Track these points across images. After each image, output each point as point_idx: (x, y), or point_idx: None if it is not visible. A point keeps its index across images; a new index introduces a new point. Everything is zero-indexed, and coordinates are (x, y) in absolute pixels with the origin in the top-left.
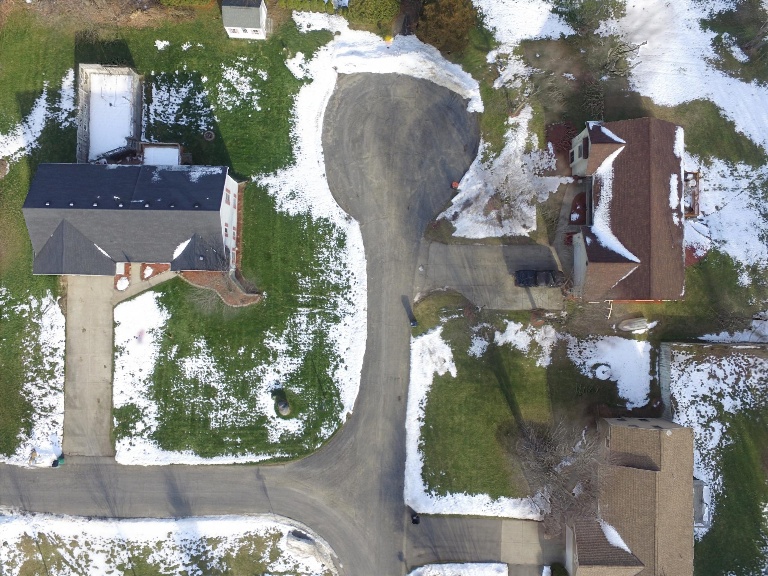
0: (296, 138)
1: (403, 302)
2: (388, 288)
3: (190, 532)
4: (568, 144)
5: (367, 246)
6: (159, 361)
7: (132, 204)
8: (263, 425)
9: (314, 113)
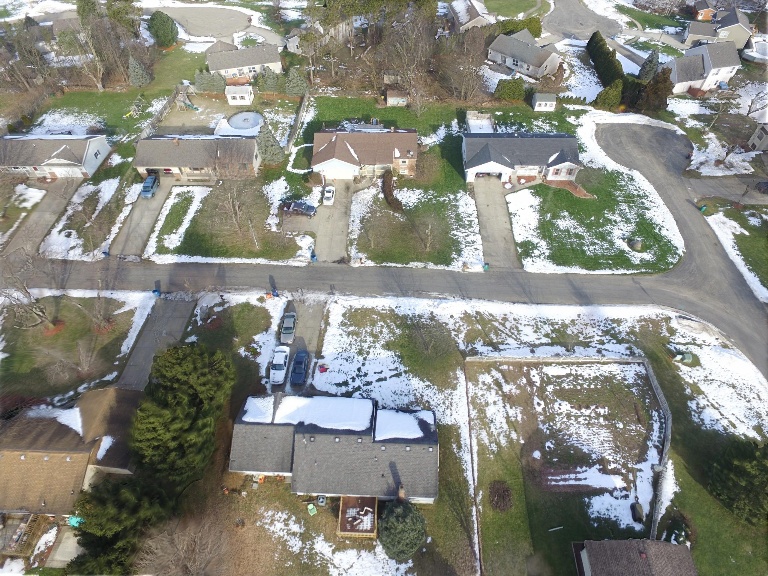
0: (583, 144)
1: (688, 202)
2: (674, 196)
3: (595, 314)
4: (746, 144)
5: (649, 180)
6: (540, 220)
7: None
8: (624, 255)
9: (589, 135)
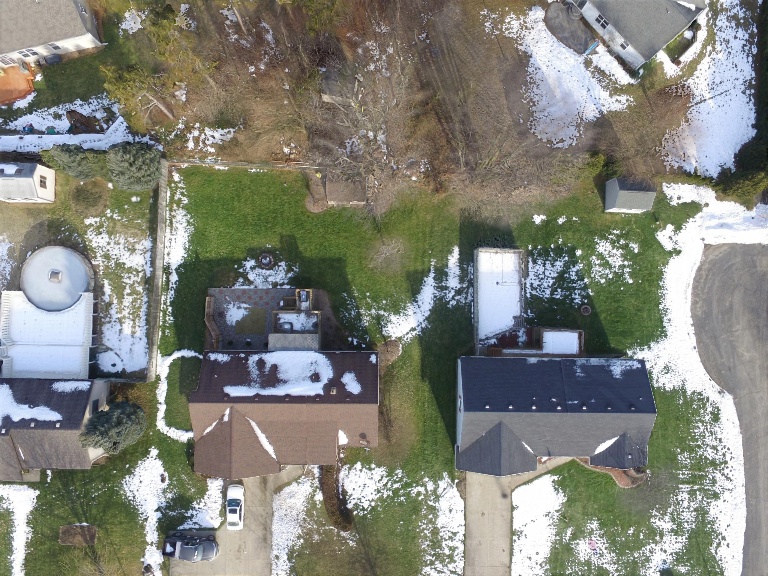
0: (666, 310)
1: None
2: (764, 463)
3: None
4: None
5: (742, 421)
6: (555, 544)
7: (569, 406)
8: None
9: (683, 285)
